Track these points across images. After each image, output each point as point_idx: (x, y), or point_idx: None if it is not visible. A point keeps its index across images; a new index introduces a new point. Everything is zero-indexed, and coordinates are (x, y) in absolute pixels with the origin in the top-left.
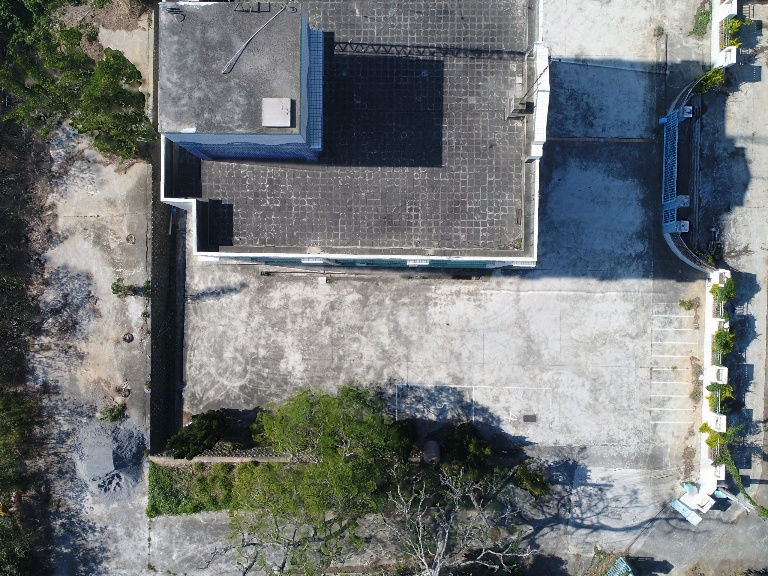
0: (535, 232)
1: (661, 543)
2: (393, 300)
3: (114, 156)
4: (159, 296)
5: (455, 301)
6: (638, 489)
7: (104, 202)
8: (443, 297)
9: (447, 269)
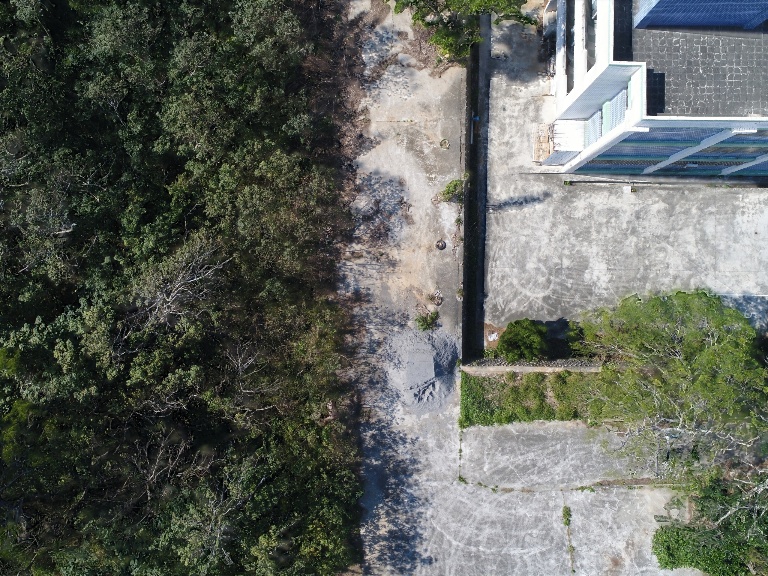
0: None
1: None
2: (700, 209)
3: (429, 60)
4: (466, 204)
5: (763, 210)
6: None
7: (418, 107)
8: (751, 206)
9: (755, 177)
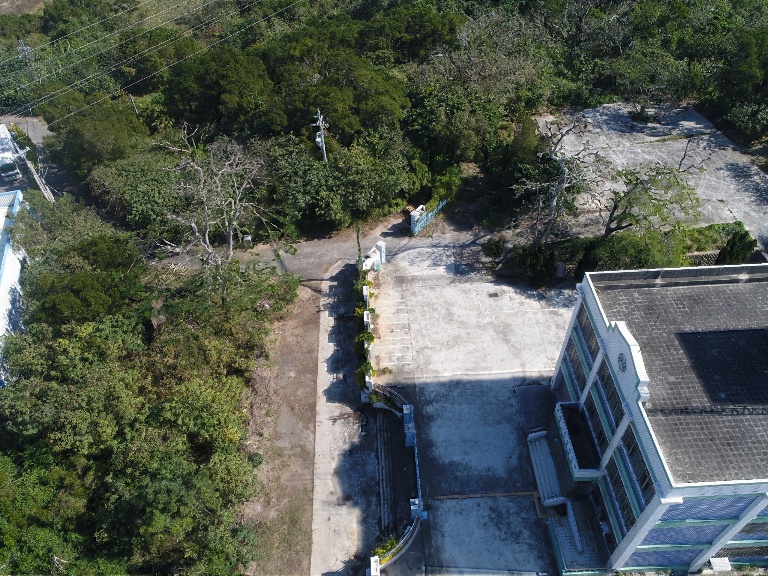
0: (593, 287)
1: (388, 245)
2: None
3: None
4: None
5: None
6: (409, 266)
7: None
8: None
9: None
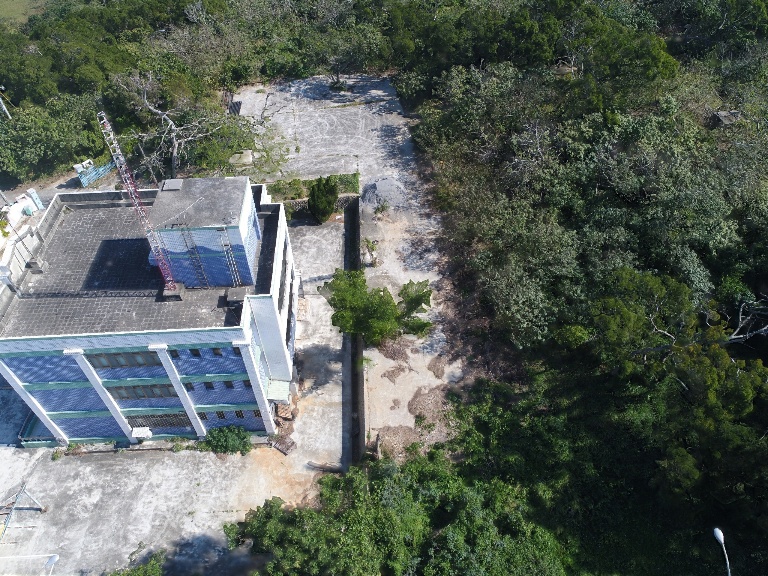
0: (52, 204)
1: None
2: None
3: None
4: None
5: None
6: None
7: None
8: None
9: None
